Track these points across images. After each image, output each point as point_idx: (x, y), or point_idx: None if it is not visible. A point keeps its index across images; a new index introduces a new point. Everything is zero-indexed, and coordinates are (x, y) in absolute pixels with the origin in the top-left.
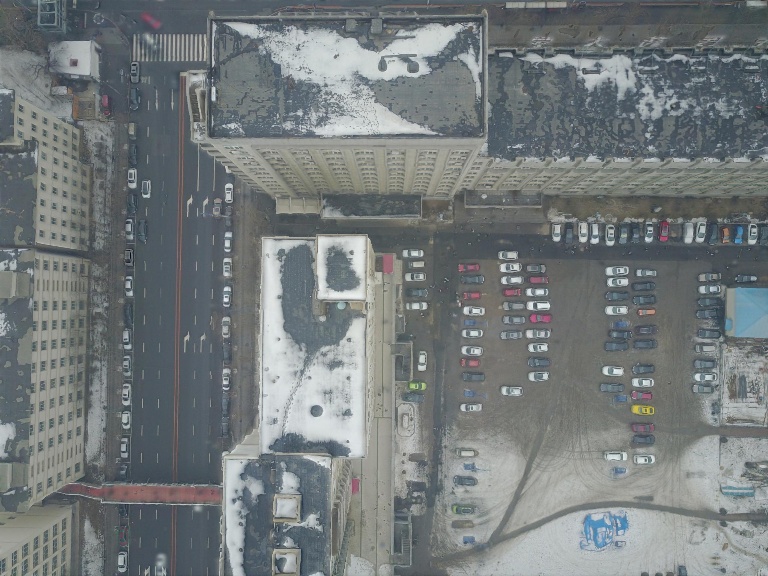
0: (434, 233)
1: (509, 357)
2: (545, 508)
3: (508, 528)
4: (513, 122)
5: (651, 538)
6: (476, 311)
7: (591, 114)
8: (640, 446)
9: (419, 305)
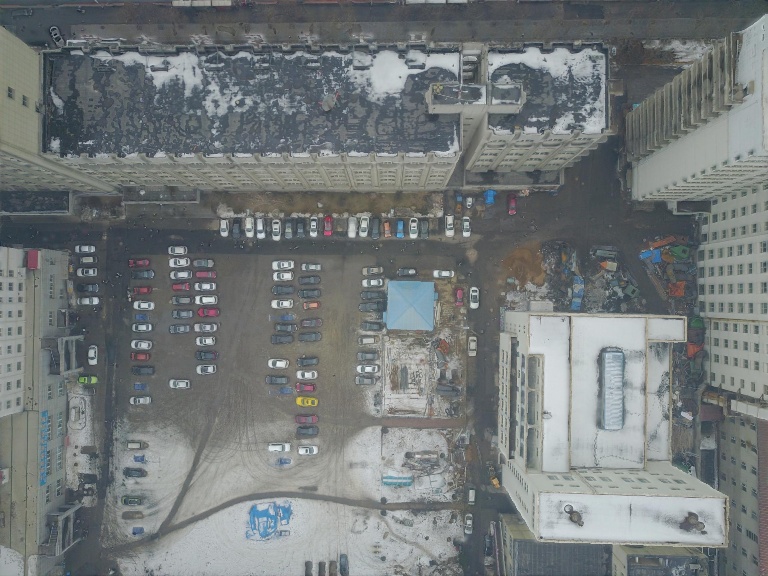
0: (107, 229)
1: (179, 351)
2: (212, 499)
3: (177, 519)
4: (84, 119)
5: (315, 527)
6: (144, 305)
7: (159, 110)
8: (305, 437)
9: (89, 300)
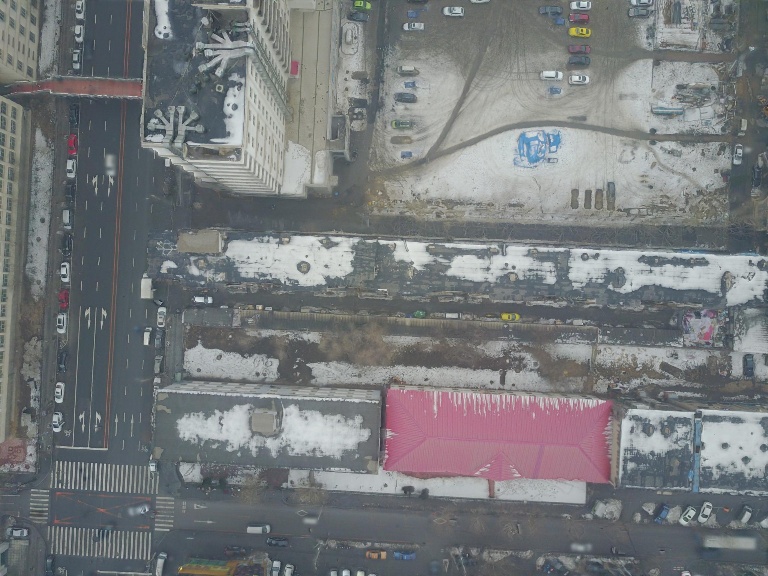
0: None
1: None
2: (481, 126)
3: (445, 145)
4: None
5: (582, 156)
6: None
7: None
8: (576, 68)
9: None
